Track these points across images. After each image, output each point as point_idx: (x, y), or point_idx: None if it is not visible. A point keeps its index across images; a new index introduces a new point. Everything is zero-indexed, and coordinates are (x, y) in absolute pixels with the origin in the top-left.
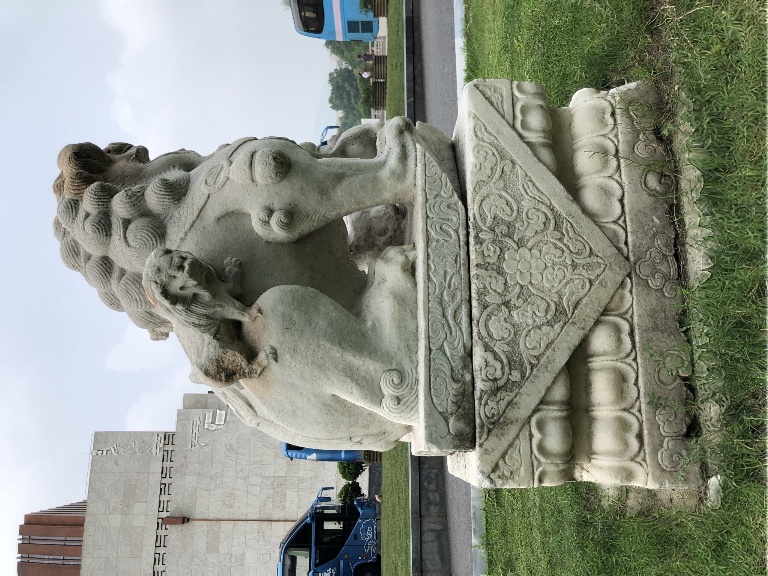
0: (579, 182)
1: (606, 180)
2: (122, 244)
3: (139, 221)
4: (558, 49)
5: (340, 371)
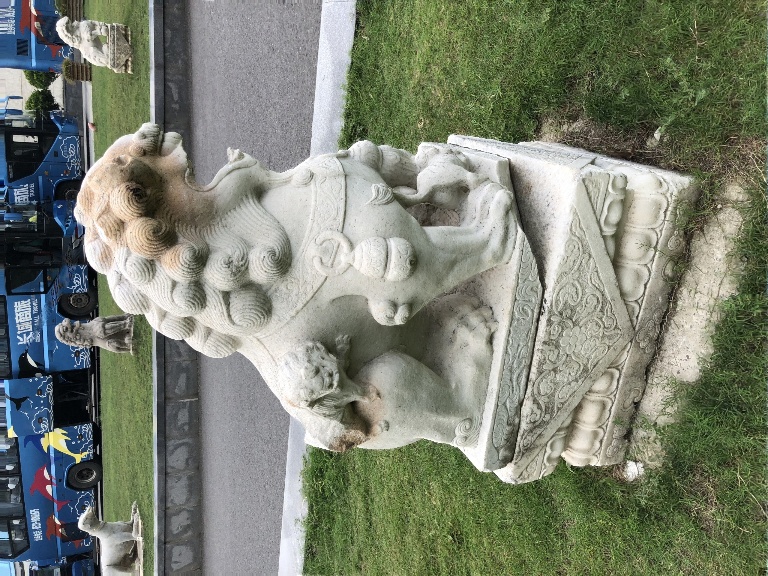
0: (621, 262)
1: (642, 267)
2: (225, 321)
3: (244, 298)
4: (586, 5)
5: (431, 428)
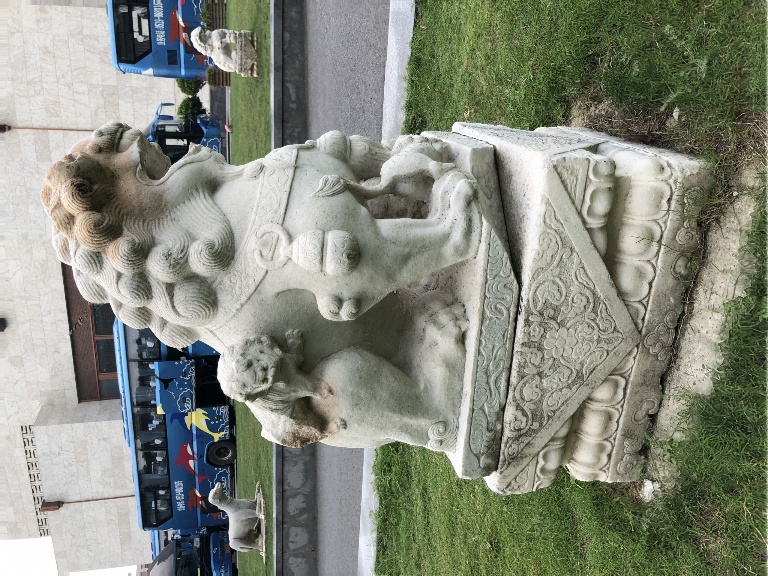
0: (619, 257)
1: (644, 264)
2: (170, 312)
3: (187, 290)
4: None
5: (398, 429)
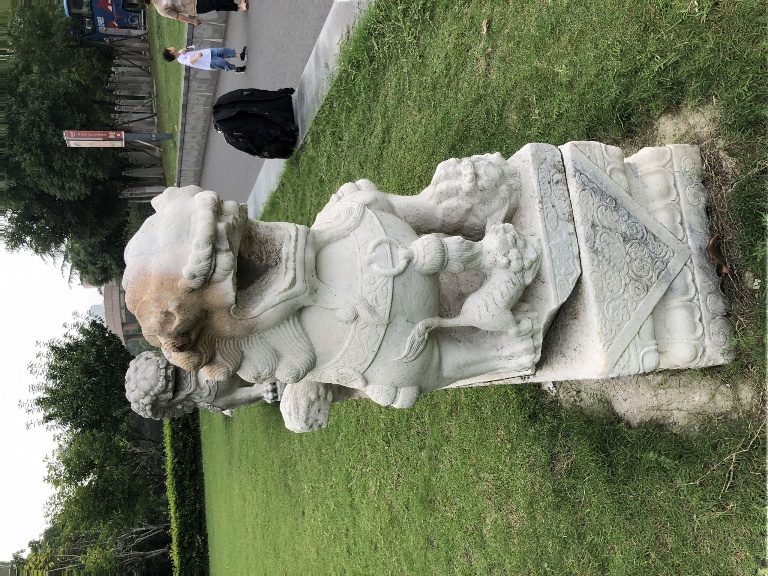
0: None
1: None
2: None
3: None
4: None
5: None
